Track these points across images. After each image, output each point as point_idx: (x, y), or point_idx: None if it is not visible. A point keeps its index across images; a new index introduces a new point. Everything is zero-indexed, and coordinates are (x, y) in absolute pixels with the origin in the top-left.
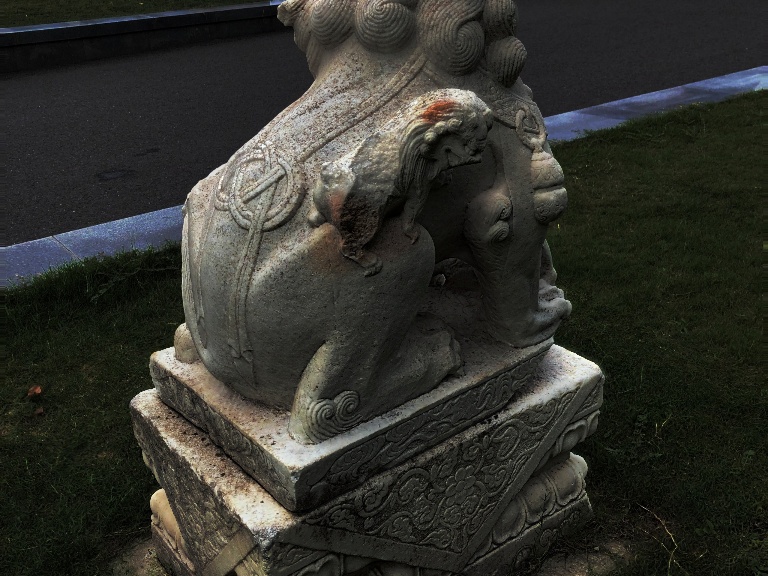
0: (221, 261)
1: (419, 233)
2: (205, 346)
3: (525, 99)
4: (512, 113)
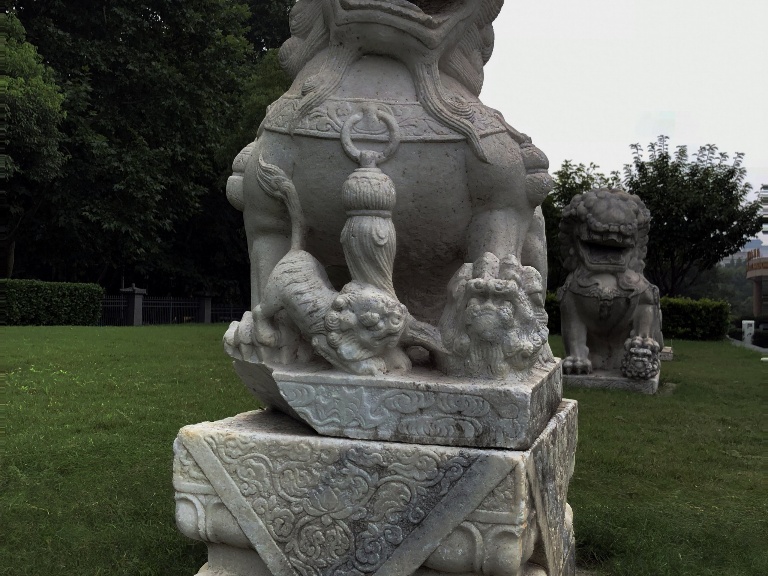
0: None
1: None
2: None
3: None
4: None
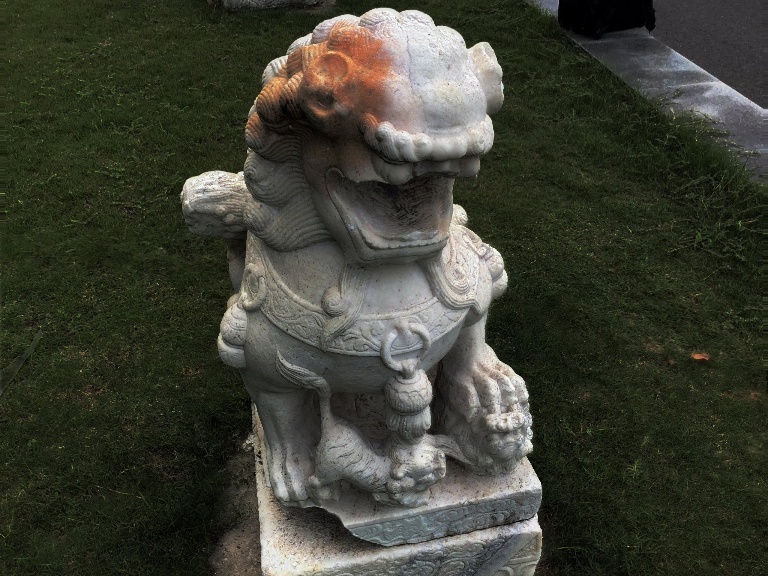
0: None
1: (231, 259)
2: None
3: (274, 272)
4: (251, 258)
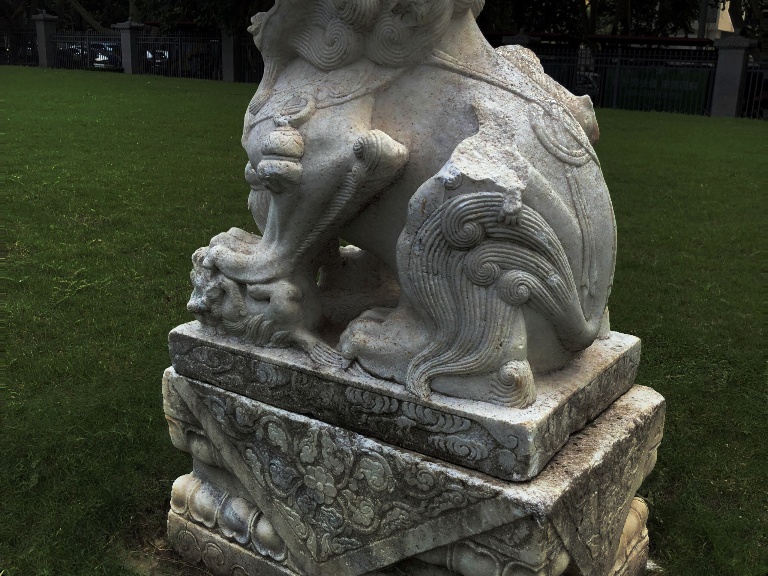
0: (608, 204)
1: None
2: None
3: None
4: None
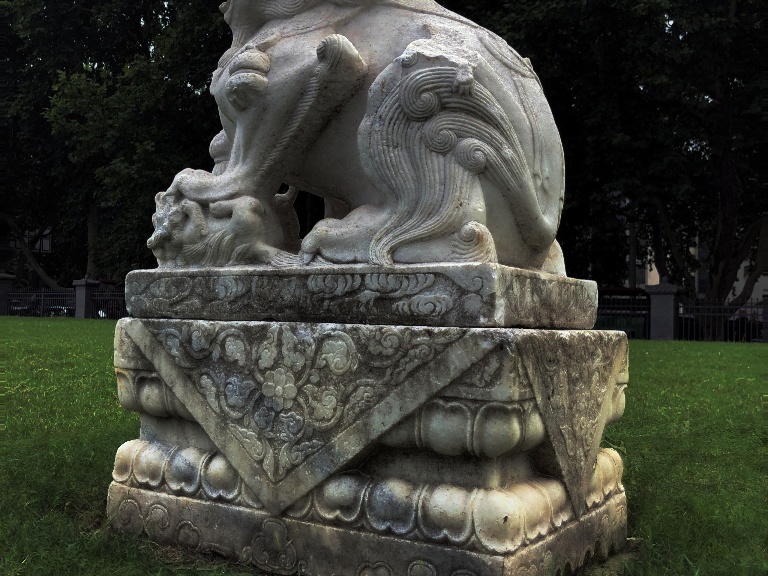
0: None
1: None
2: (544, 211)
3: None
4: None
